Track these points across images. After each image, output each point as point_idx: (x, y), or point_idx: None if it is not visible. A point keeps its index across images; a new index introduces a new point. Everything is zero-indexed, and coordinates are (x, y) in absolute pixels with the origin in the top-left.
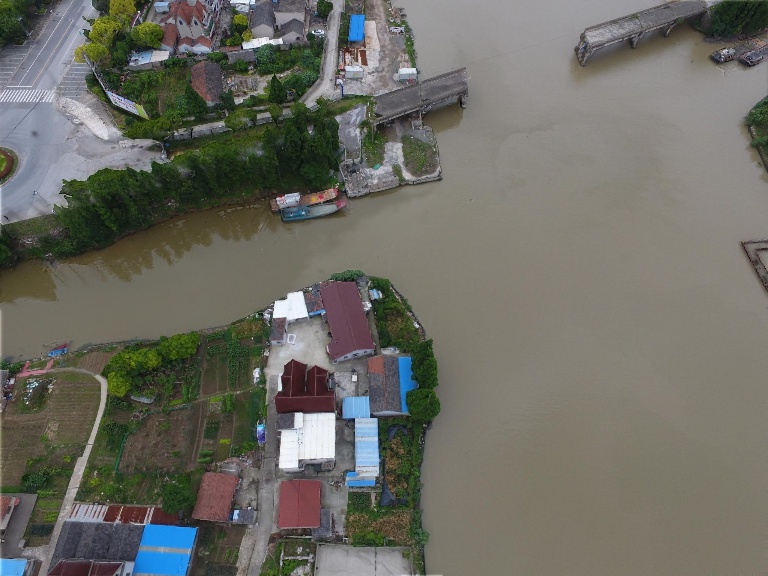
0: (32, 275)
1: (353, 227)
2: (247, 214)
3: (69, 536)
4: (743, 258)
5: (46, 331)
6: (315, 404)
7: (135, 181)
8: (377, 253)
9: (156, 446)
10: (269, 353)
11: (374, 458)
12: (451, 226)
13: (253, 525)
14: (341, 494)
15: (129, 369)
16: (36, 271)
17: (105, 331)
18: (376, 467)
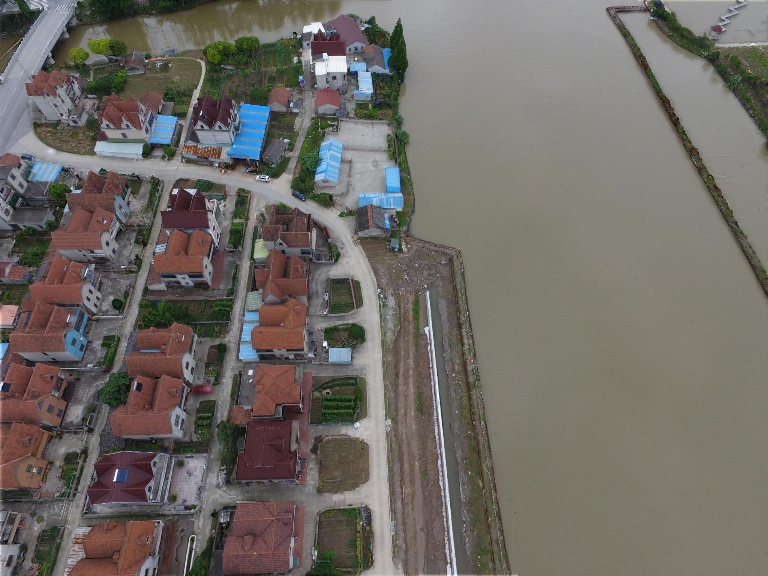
0: (140, 30)
1: (350, 1)
2: (277, 9)
3: None
4: (606, 16)
5: None
6: (334, 48)
7: None
8: (367, 12)
9: (239, 87)
10: (302, 51)
11: (370, 86)
12: (415, 0)
13: (301, 114)
14: (351, 103)
15: (219, 50)
16: (142, 29)
17: None
18: (371, 90)
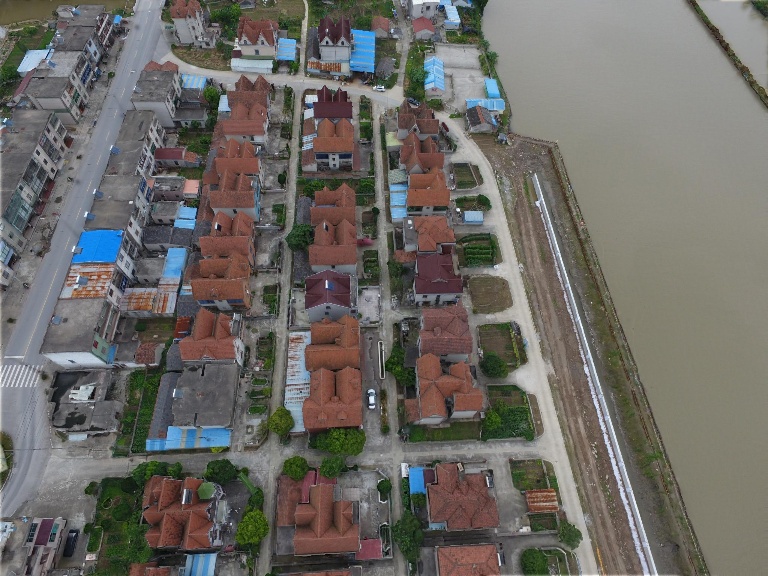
0: None
1: None
2: None
3: (315, 31)
4: None
5: None
6: None
7: None
8: None
9: None
10: None
11: (457, 17)
12: None
13: (400, 39)
14: (442, 31)
15: None
16: None
17: None
18: (459, 20)
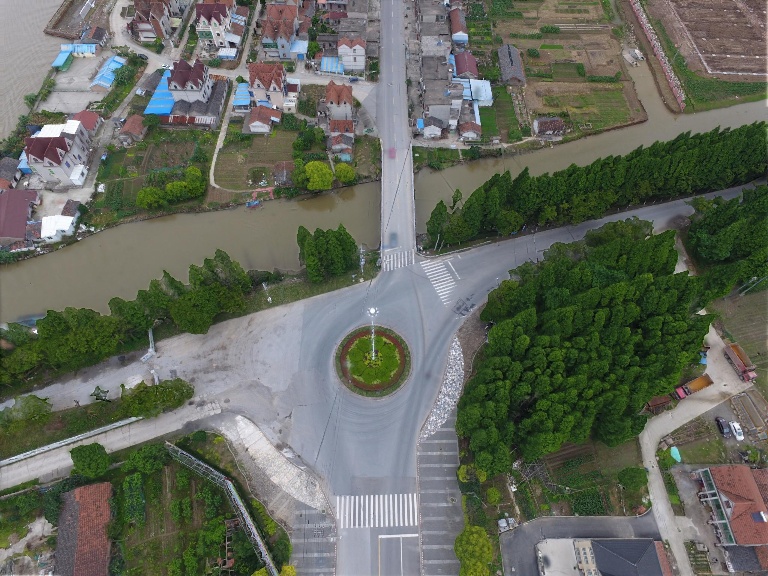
0: None
1: None
2: None
3: None
4: None
5: (284, 237)
6: None
7: (152, 286)
8: None
9: None
10: None
11: None
12: None
13: None
14: None
15: None
16: None
17: (225, 225)
18: None
